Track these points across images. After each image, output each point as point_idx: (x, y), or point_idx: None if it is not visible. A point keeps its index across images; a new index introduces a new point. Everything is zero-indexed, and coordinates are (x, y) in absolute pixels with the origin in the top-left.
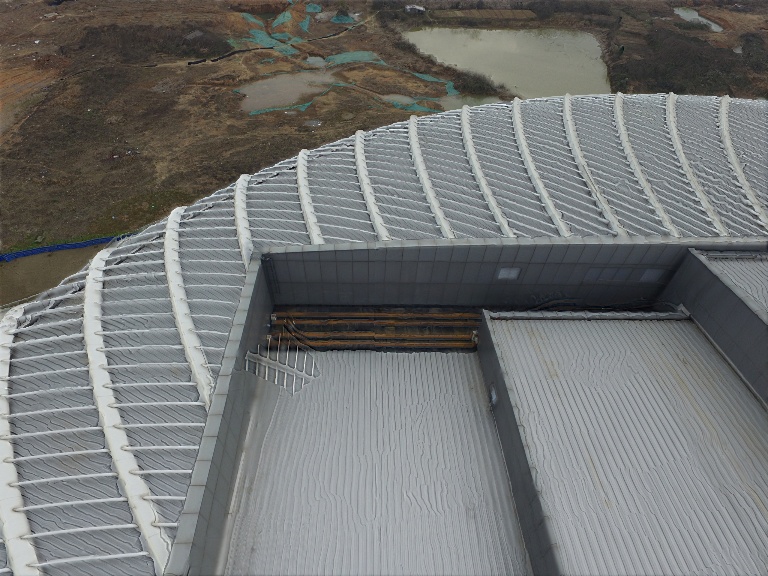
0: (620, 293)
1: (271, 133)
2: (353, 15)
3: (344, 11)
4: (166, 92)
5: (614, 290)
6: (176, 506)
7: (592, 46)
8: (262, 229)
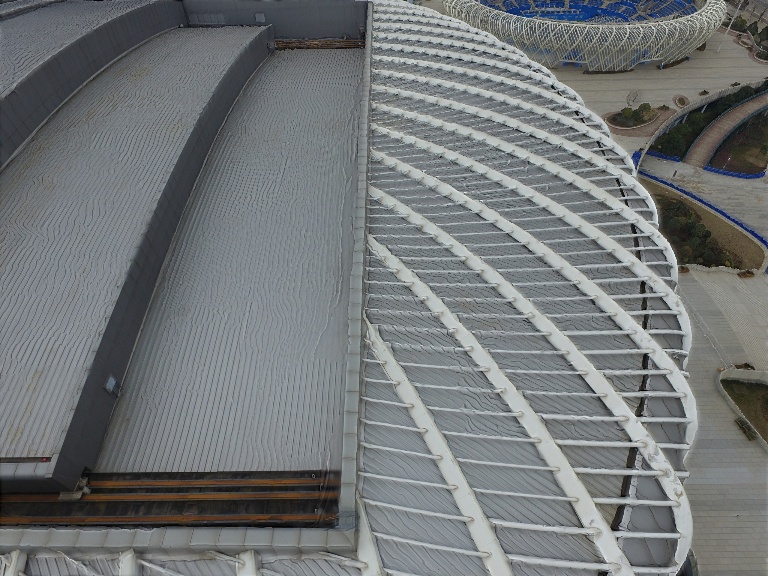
0: None
1: None
2: None
3: None
4: None
5: None
6: (373, 265)
7: None
8: None
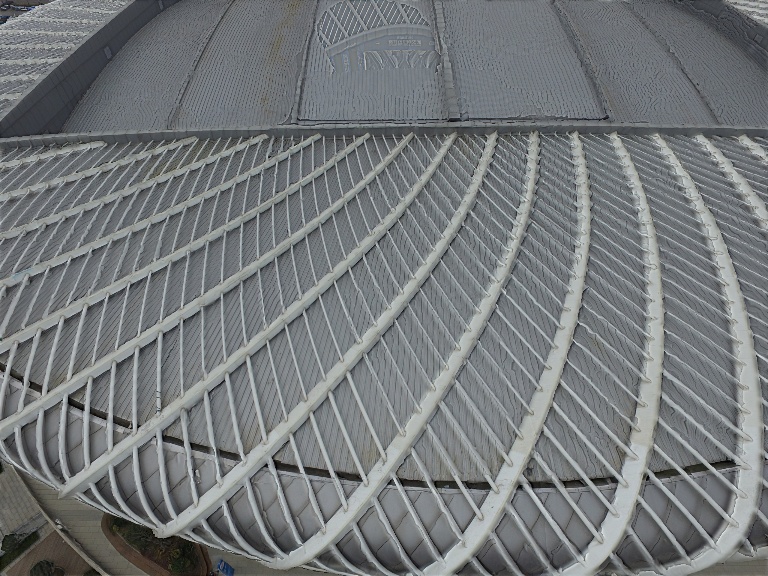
0: None
1: None
2: None
3: None
4: None
5: None
6: None
7: None
8: None
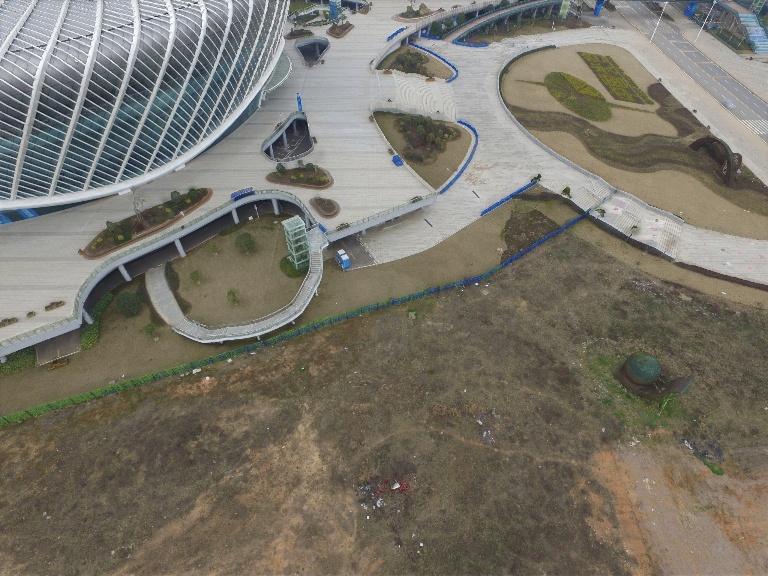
0: None
1: None
2: None
3: None
4: None
5: None
6: None
7: None
8: (90, 4)
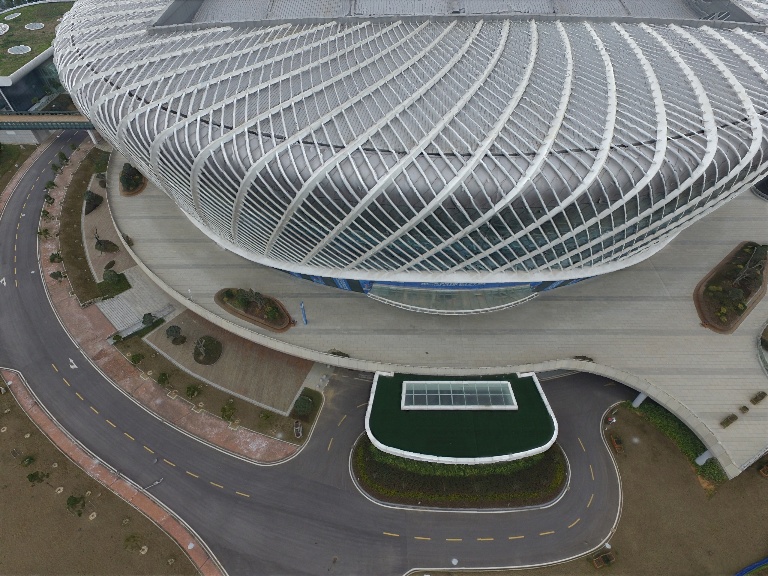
0: None
1: None
2: None
3: None
4: None
5: None
6: None
7: None
8: None
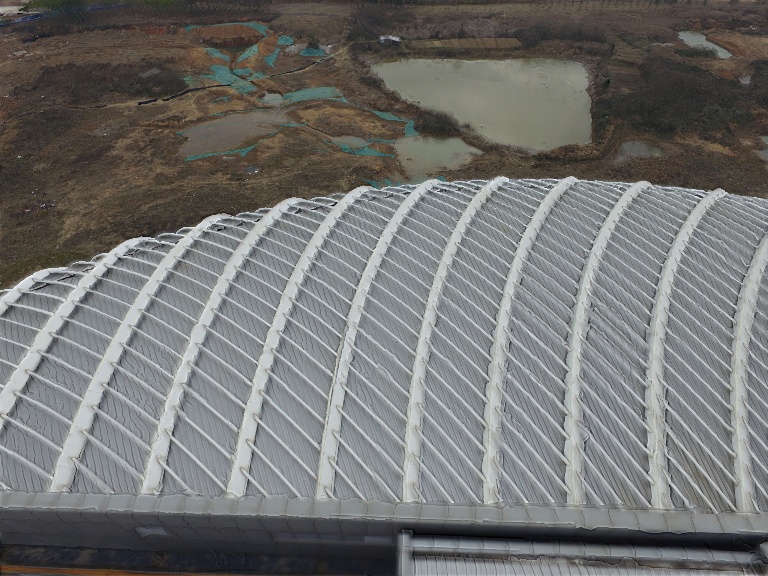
0: (337, 561)
1: (200, 182)
2: (325, 47)
3: (314, 44)
4: (106, 135)
5: (329, 555)
6: None
7: (582, 76)
8: None
